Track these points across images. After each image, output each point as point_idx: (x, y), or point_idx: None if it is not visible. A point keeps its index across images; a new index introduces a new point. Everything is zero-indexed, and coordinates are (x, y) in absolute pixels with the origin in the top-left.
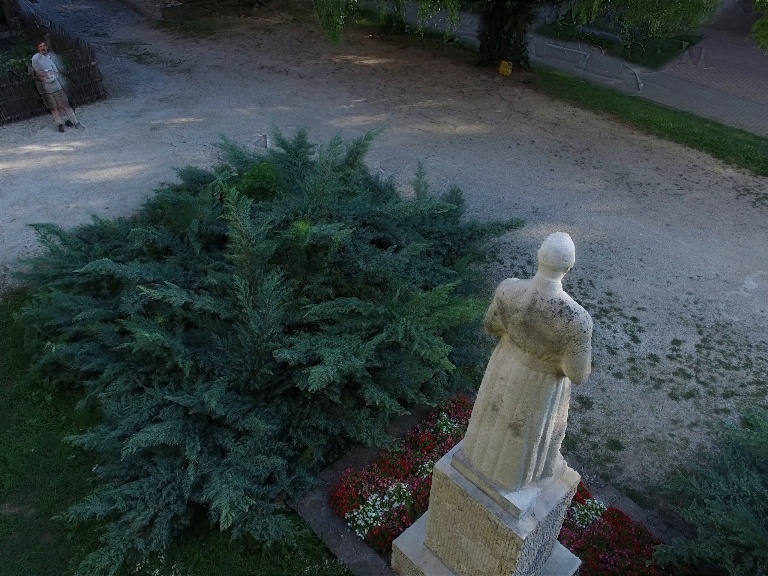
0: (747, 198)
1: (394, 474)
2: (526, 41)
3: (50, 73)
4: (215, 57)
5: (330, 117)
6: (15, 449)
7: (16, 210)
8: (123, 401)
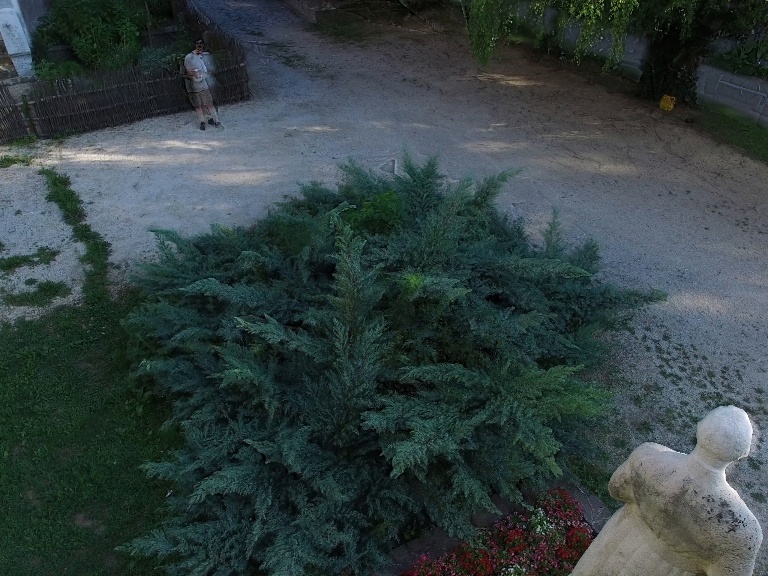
0: None
1: (473, 572)
2: (696, 75)
3: (199, 73)
4: (360, 65)
5: (466, 140)
6: (100, 457)
7: (147, 205)
8: (206, 430)
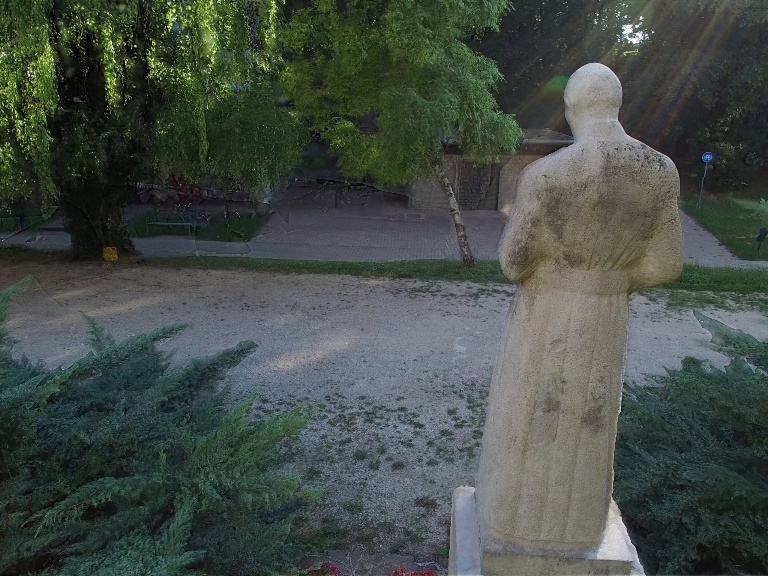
0: (402, 295)
1: None
2: (123, 224)
3: None
4: None
5: None
6: None
7: None
8: None
